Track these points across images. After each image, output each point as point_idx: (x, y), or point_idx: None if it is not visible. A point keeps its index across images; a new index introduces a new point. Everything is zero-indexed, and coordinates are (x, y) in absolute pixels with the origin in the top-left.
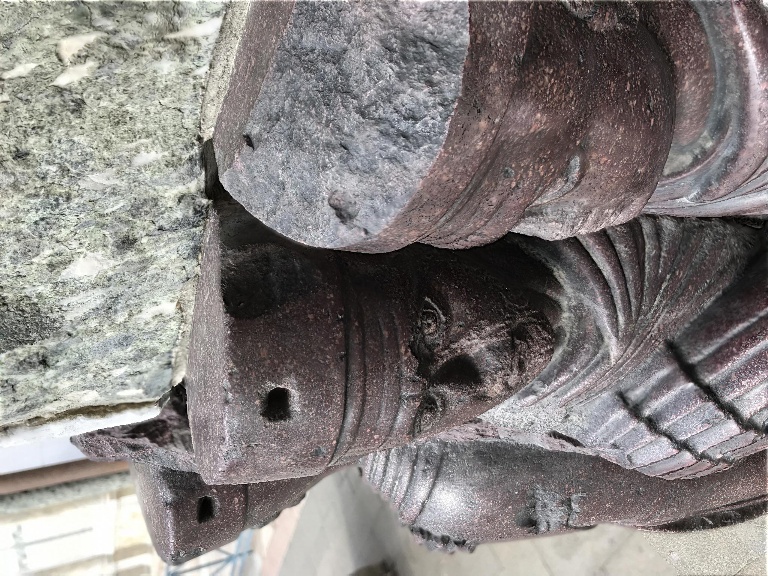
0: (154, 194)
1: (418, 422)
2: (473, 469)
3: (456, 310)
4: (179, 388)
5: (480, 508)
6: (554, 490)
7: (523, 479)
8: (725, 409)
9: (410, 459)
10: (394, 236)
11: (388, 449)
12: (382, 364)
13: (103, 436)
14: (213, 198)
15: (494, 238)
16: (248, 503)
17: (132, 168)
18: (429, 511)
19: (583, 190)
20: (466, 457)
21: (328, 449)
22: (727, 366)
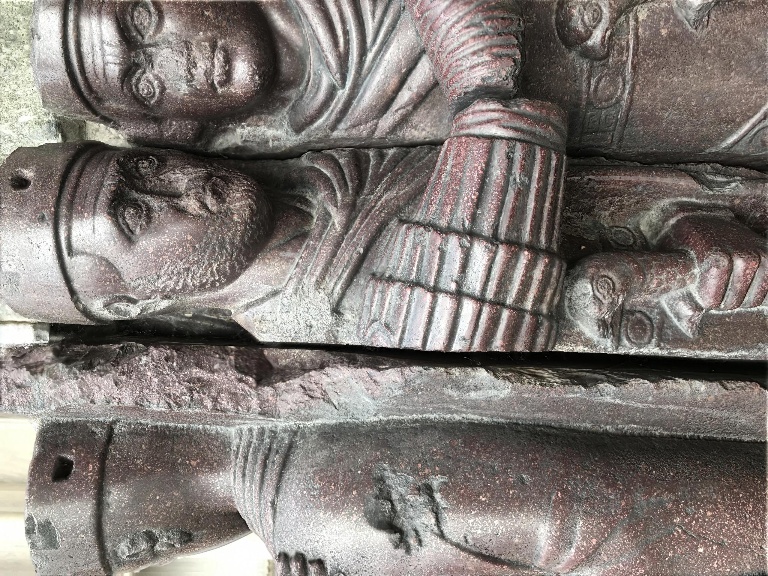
0: (32, 145)
1: (121, 212)
2: (315, 449)
3: (171, 163)
4: (64, 343)
5: (322, 494)
6: (405, 471)
7: (366, 456)
8: None
9: (263, 453)
10: (48, 33)
11: (247, 448)
12: (96, 168)
13: (1, 371)
14: None
15: (119, 48)
16: (104, 481)
17: (18, 124)
18: (279, 515)
19: (170, 23)
20: (311, 440)
21: (49, 216)
22: (424, 198)
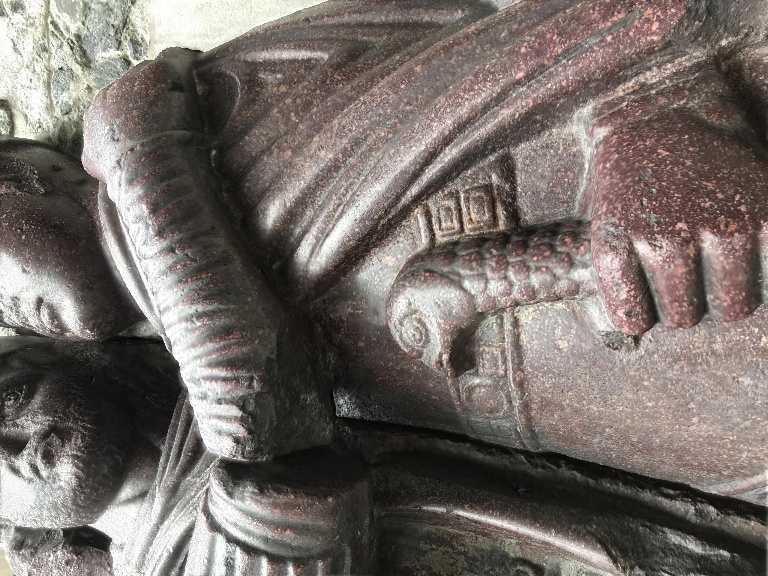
0: None
1: None
2: None
3: None
4: None
5: None
6: None
7: None
8: None
9: None
10: None
11: None
12: None
13: None
14: (21, 334)
15: None
16: None
17: None
18: None
19: None
20: None
21: None
22: None
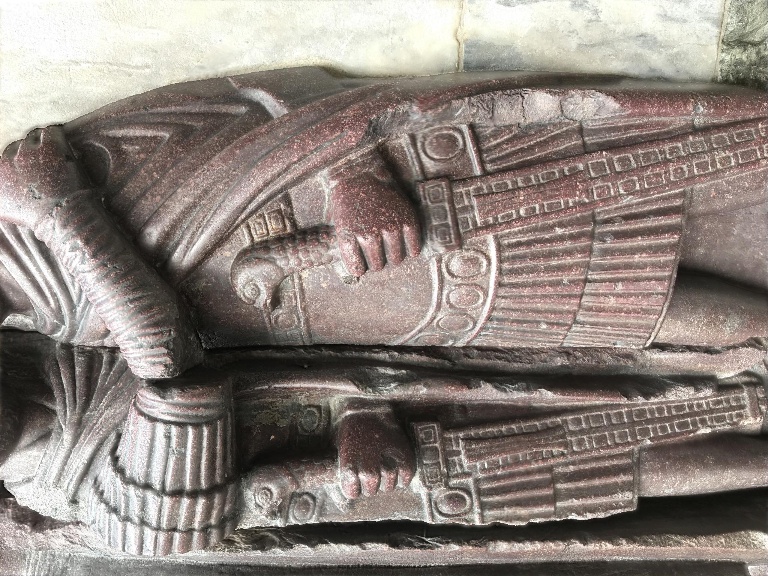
0: None
1: None
2: None
3: None
4: None
5: None
6: None
7: None
8: (116, 470)
9: (44, 573)
10: None
11: (34, 565)
12: None
13: None
14: None
15: None
16: None
17: None
18: None
19: None
20: (75, 570)
21: None
22: (121, 439)
